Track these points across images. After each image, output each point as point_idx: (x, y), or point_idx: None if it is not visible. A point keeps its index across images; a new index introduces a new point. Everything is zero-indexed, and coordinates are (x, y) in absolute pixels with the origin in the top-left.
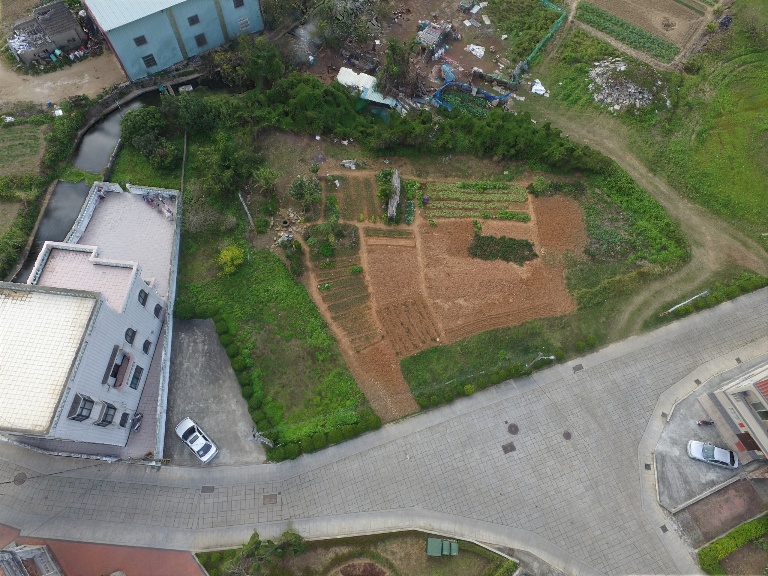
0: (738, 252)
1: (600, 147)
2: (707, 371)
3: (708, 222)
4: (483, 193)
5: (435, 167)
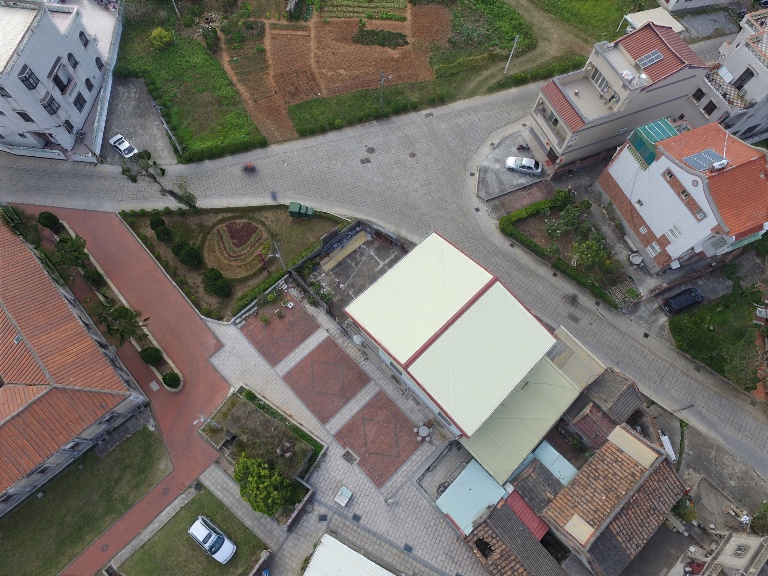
0: (578, 45)
1: None
2: None
3: (557, 26)
4: (370, 2)
5: None
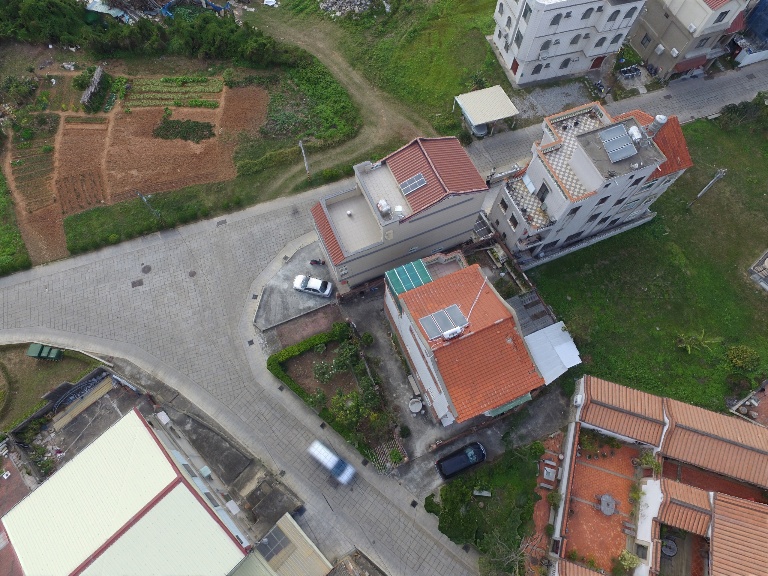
0: (407, 130)
1: (310, 47)
2: None
3: (389, 106)
4: (182, 86)
5: (146, 66)
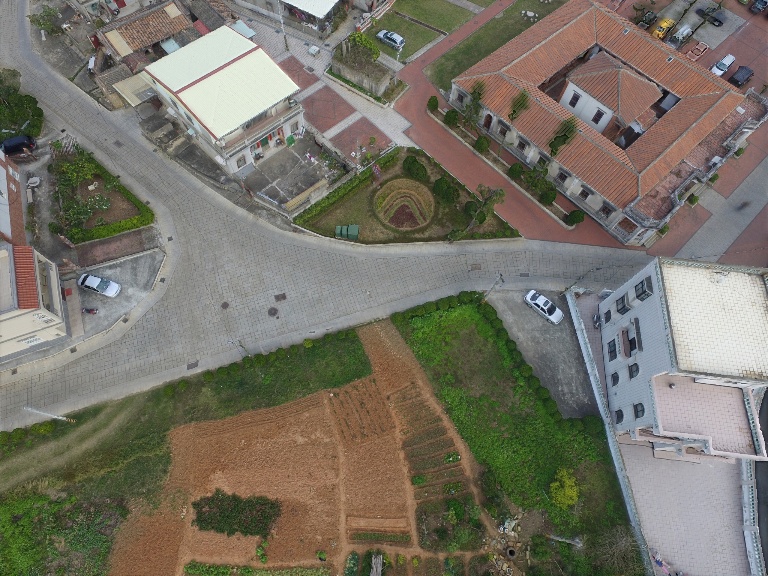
0: None
1: None
2: (57, 361)
3: None
4: None
5: None
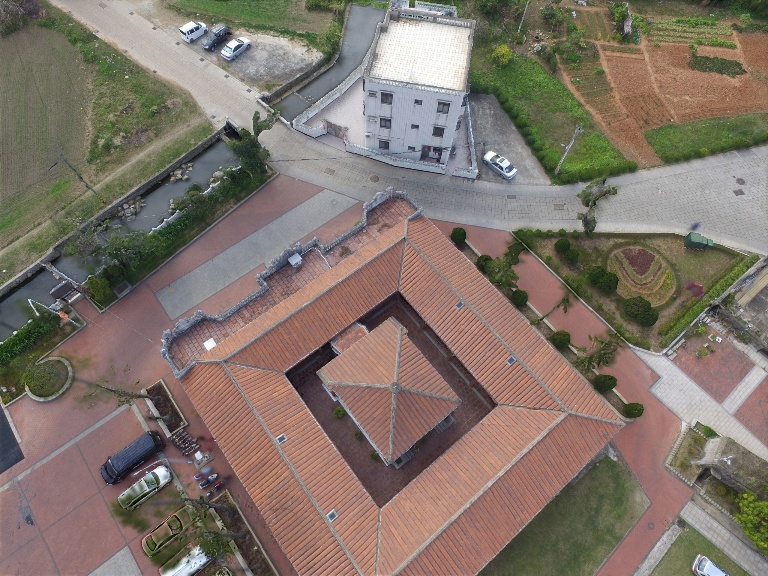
0: None
1: None
2: None
3: None
4: (695, 27)
5: (652, 8)
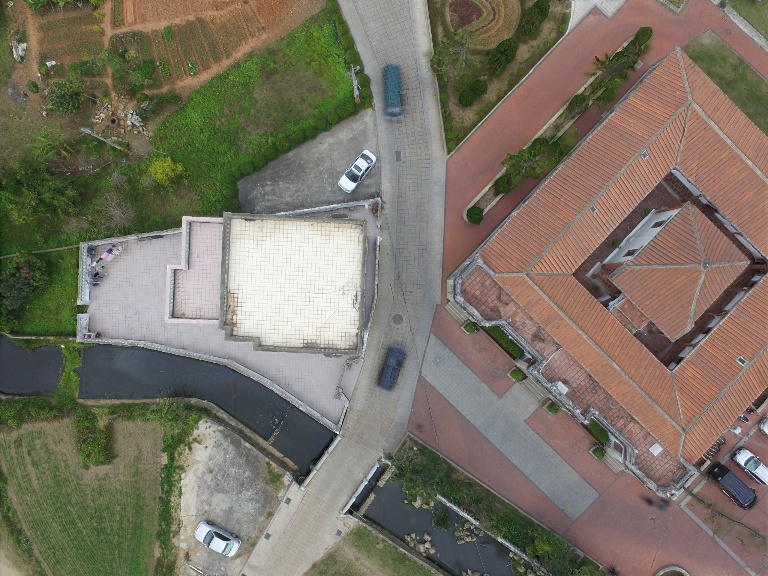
0: None
1: None
2: None
3: None
4: None
5: None
